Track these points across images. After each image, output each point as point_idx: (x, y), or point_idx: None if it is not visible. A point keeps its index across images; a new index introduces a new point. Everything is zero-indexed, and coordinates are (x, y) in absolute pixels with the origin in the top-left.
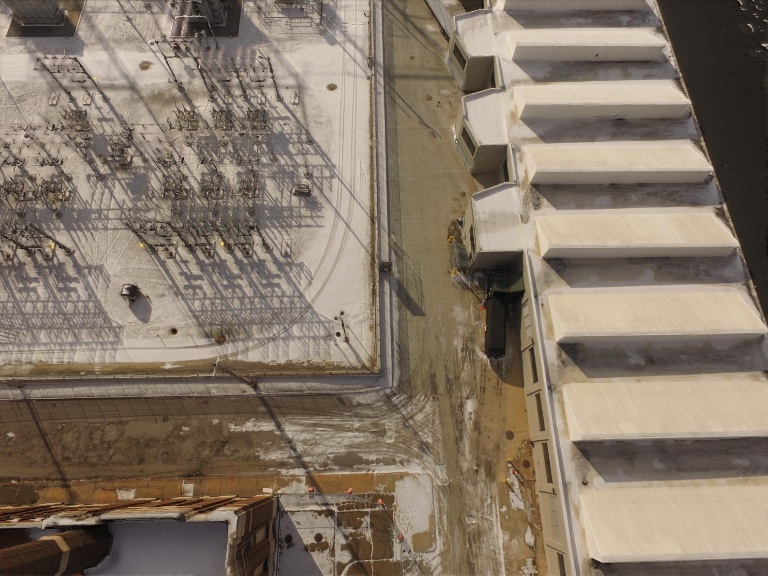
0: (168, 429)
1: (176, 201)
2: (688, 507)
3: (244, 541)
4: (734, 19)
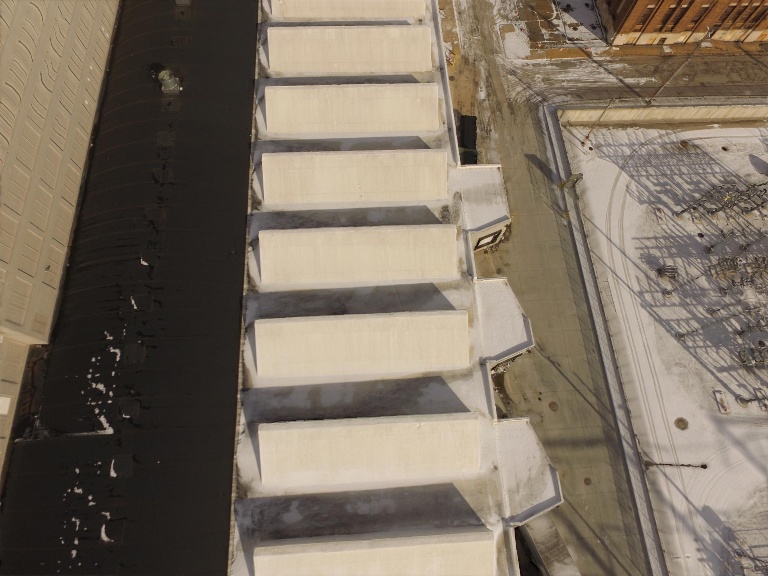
0: (698, 79)
1: None
2: (357, 5)
3: None
4: (133, 488)
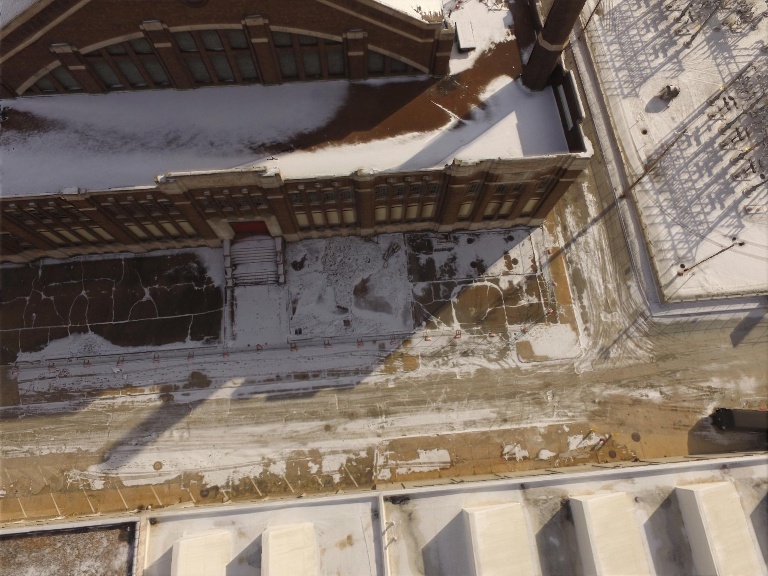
0: None
1: (765, 110)
2: None
3: (553, 177)
4: None
